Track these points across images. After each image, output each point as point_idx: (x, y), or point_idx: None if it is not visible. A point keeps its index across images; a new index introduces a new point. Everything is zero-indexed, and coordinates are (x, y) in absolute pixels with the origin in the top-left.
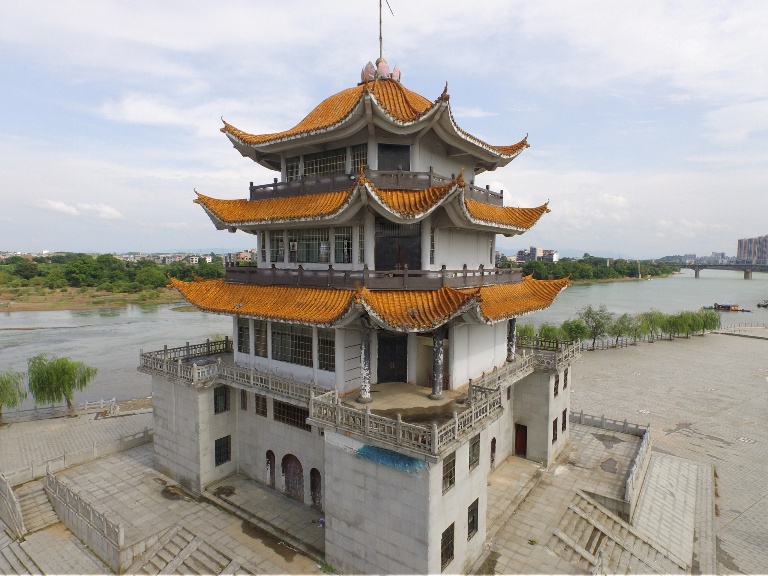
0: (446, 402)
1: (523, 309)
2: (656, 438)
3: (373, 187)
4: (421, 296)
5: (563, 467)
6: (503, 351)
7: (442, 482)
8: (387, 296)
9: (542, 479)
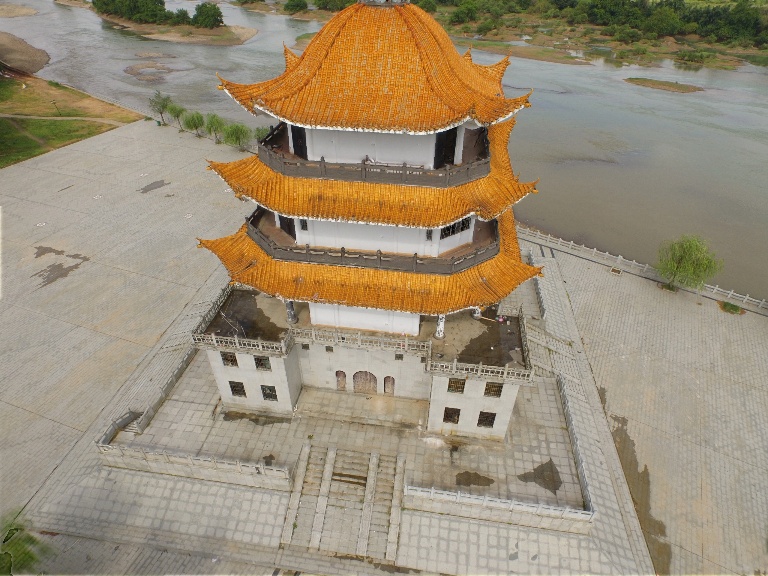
0: (285, 327)
1: (359, 303)
2: (709, 558)
3: (219, 172)
4: (264, 255)
5: (441, 442)
6: (411, 323)
7: (222, 360)
8: (253, 244)
9: (406, 430)
